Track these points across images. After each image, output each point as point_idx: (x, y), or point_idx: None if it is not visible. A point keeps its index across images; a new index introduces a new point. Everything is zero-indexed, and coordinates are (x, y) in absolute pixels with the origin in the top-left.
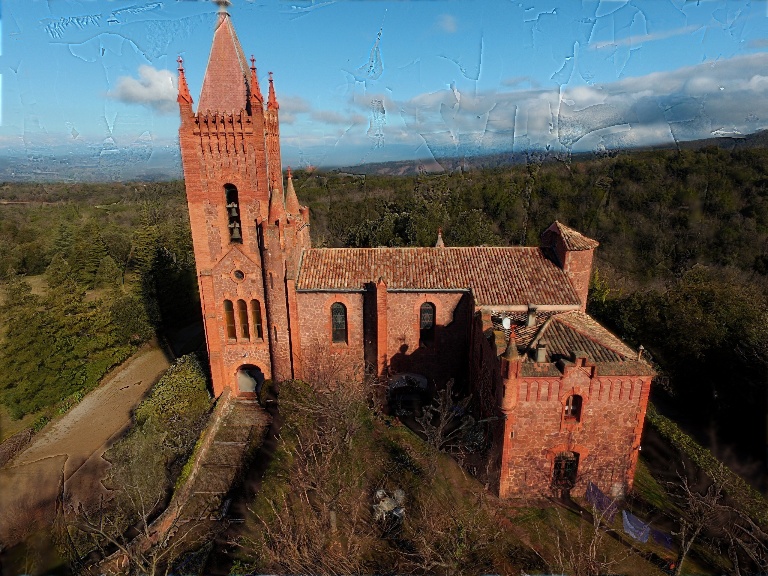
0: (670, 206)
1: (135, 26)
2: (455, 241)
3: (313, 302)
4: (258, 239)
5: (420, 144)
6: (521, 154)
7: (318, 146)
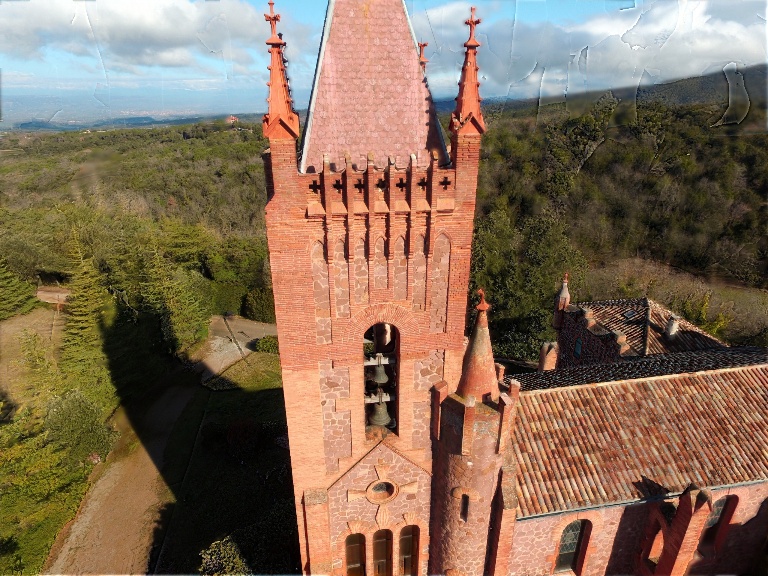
0: (748, 201)
1: None
2: (536, 266)
3: (534, 526)
4: (432, 424)
5: None
6: (543, 127)
7: None
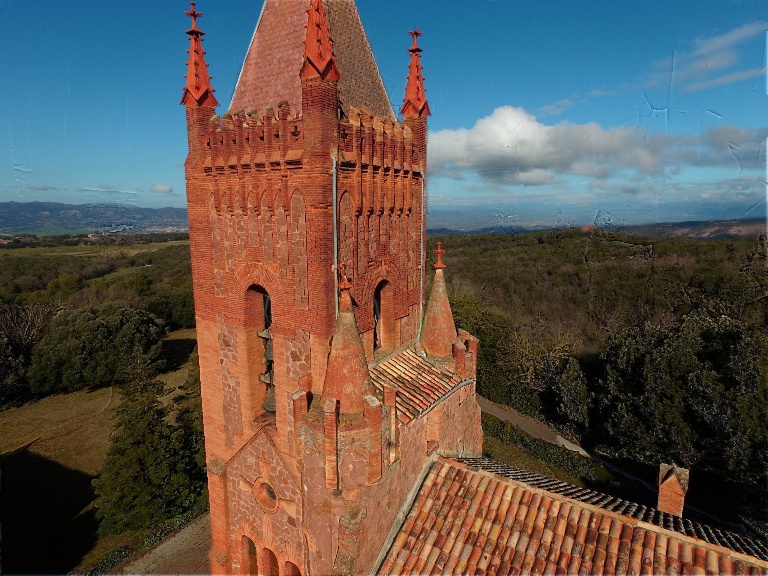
0: None
1: None
2: None
3: None
4: None
5: (759, 199)
6: None
7: (585, 203)
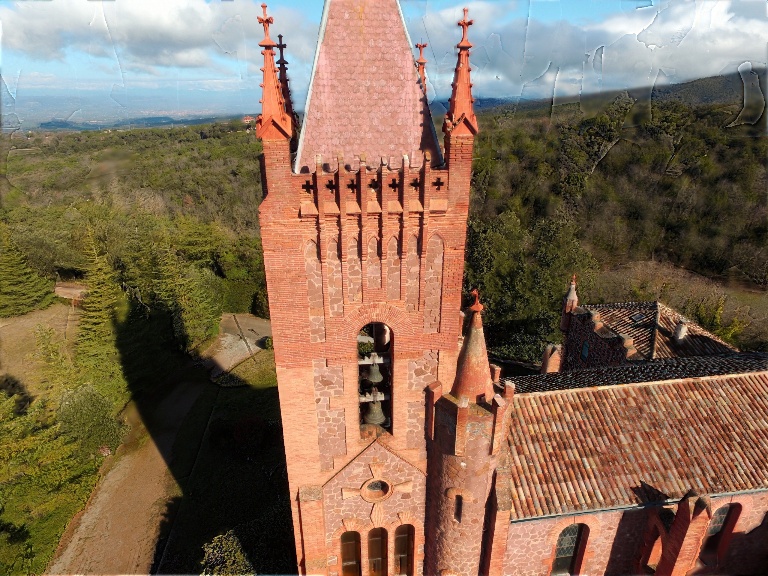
0: (767, 203)
1: None
2: (545, 268)
3: (530, 528)
4: (427, 424)
5: None
6: (556, 127)
7: (300, 113)
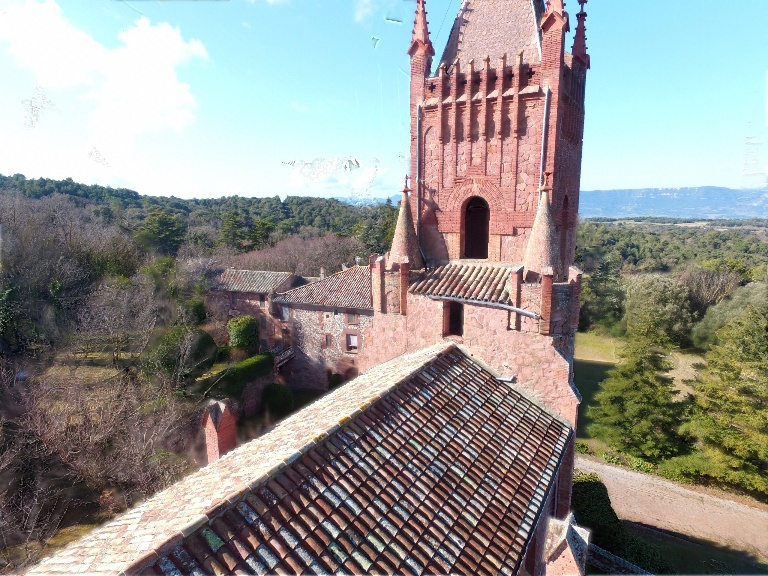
0: None
1: (22, 129)
2: None
3: None
4: None
5: None
6: None
7: None
